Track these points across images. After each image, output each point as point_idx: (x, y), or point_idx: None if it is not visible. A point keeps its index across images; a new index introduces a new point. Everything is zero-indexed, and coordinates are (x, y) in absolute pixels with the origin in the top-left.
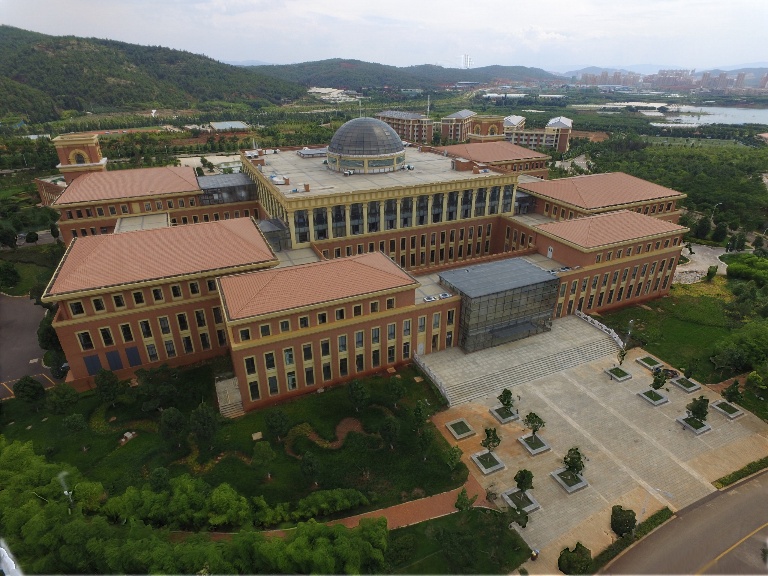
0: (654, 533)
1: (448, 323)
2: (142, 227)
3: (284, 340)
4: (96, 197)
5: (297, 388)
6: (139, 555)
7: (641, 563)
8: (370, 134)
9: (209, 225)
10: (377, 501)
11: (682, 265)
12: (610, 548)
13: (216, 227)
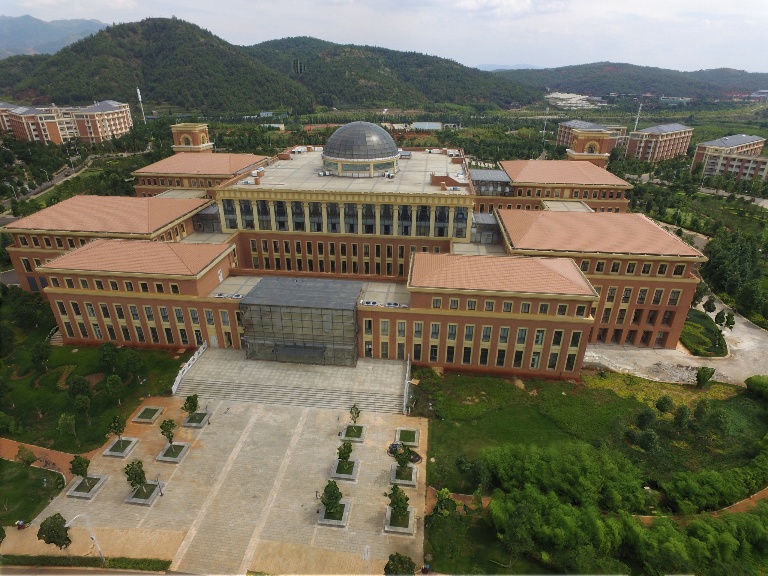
0: (122, 572)
1: (240, 324)
2: None
3: (82, 295)
4: (161, 171)
5: (103, 339)
6: None
7: None
8: (349, 138)
9: (142, 199)
10: (20, 434)
11: (700, 358)
12: (71, 557)
13: (144, 201)
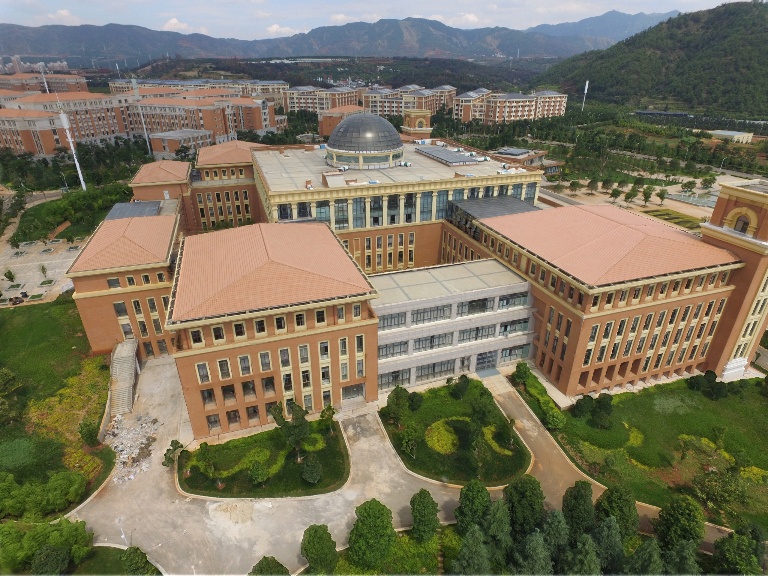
0: None
1: None
2: None
3: None
4: None
5: None
6: (86, 191)
7: None
8: None
9: None
10: None
11: None
12: None
13: None
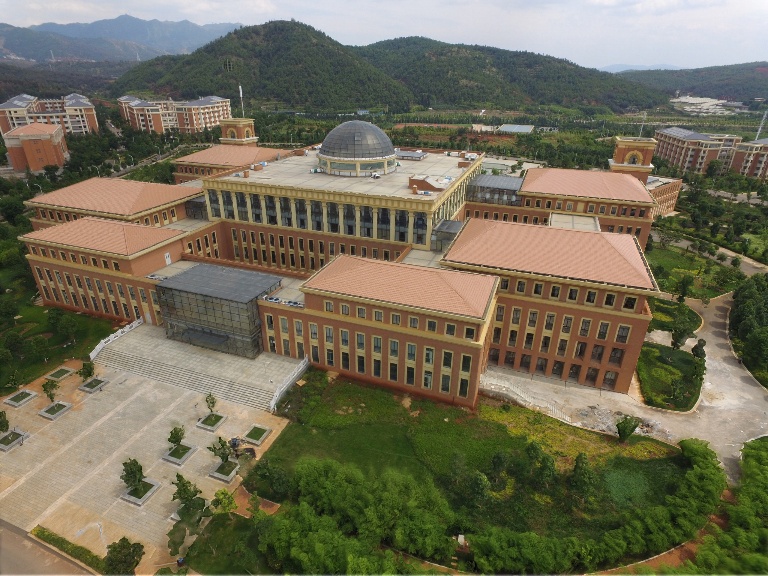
0: None
1: None
2: (196, 185)
3: (51, 263)
4: (196, 160)
5: None
6: None
7: None
8: (339, 136)
9: (140, 184)
10: None
11: (652, 408)
12: None
13: (141, 186)
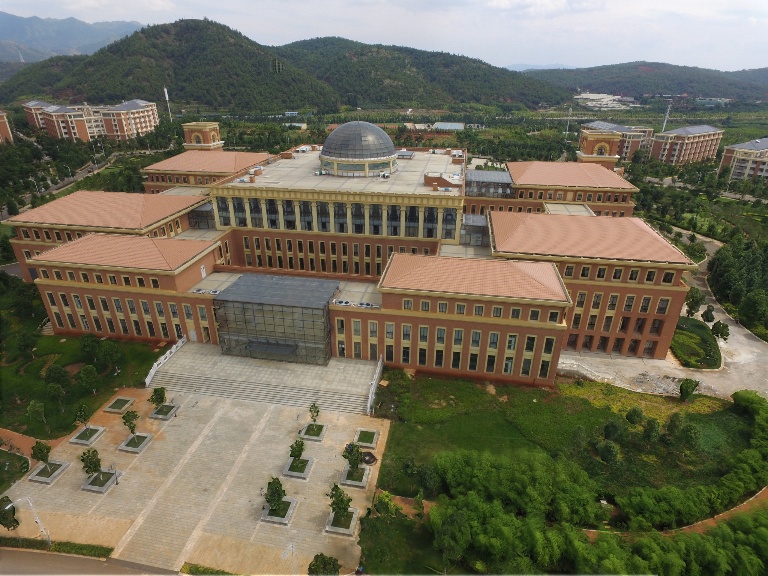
0: (65, 556)
1: None
2: (177, 194)
3: (69, 287)
4: (169, 168)
5: (90, 330)
6: None
7: (16, 565)
8: (345, 137)
9: (138, 195)
10: None
11: (690, 369)
12: (20, 539)
13: (140, 197)
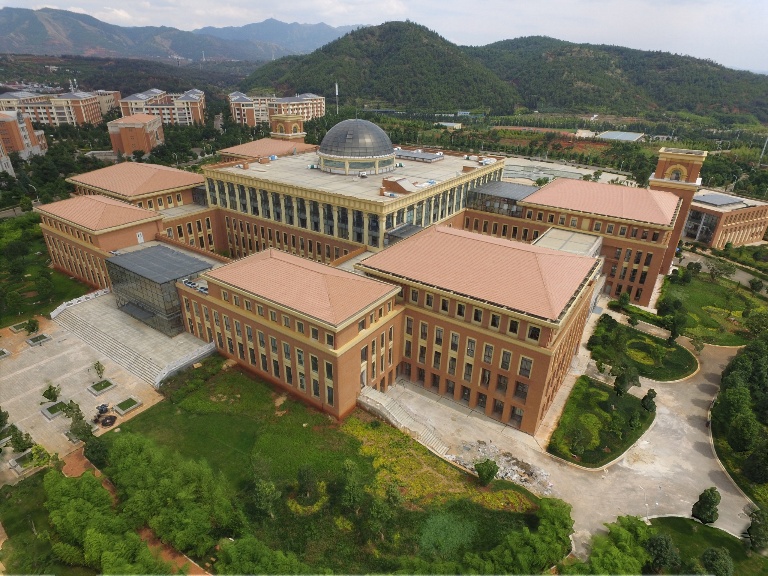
0: None
1: None
2: None
3: None
4: (236, 152)
5: None
6: None
7: None
8: (334, 134)
9: None
10: None
11: (551, 456)
12: None
13: None
